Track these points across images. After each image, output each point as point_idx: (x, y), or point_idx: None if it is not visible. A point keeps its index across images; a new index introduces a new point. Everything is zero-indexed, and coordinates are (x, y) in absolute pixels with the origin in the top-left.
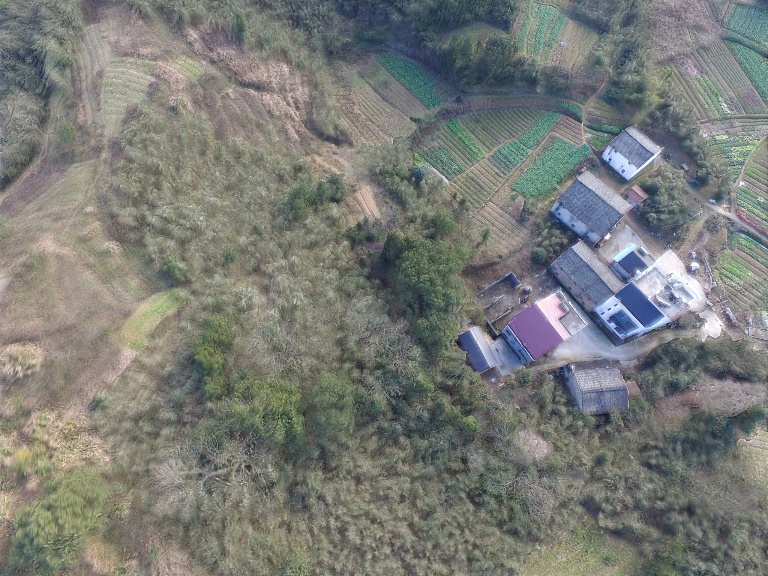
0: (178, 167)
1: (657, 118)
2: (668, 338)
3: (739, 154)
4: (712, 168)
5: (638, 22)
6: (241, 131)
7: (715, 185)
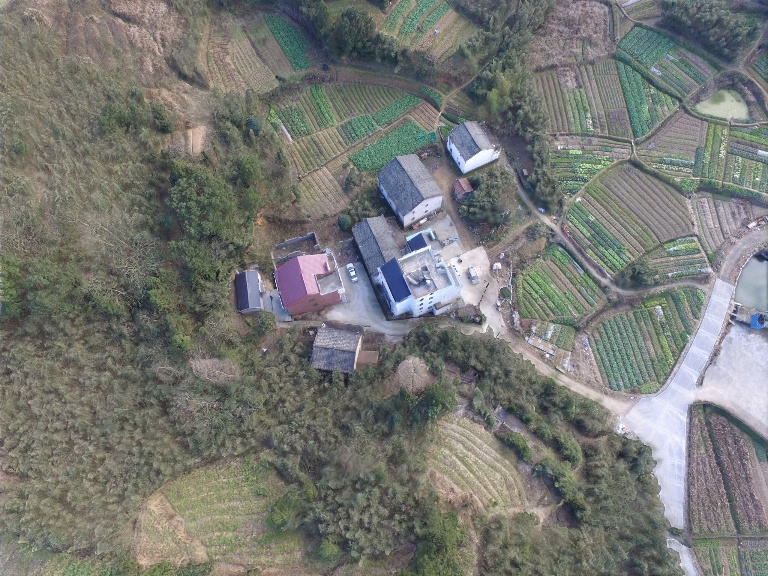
0: (8, 67)
1: (510, 120)
2: (444, 325)
3: (586, 171)
4: (543, 176)
5: (523, 26)
6: (94, 52)
7: (543, 194)
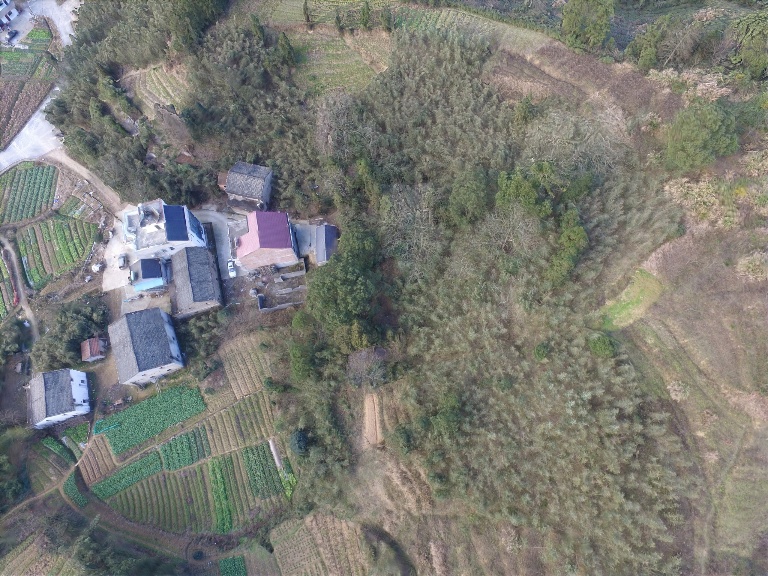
0: (599, 498)
1: None
2: None
3: None
4: None
5: None
6: (508, 568)
7: None
